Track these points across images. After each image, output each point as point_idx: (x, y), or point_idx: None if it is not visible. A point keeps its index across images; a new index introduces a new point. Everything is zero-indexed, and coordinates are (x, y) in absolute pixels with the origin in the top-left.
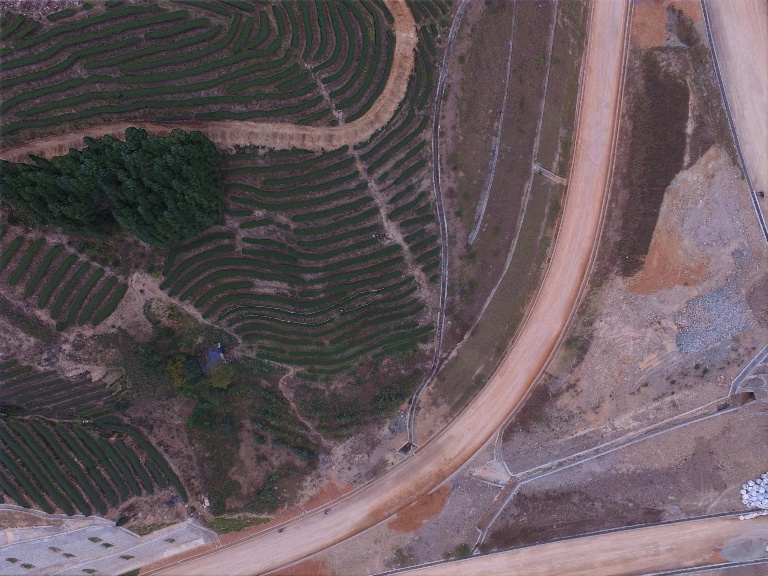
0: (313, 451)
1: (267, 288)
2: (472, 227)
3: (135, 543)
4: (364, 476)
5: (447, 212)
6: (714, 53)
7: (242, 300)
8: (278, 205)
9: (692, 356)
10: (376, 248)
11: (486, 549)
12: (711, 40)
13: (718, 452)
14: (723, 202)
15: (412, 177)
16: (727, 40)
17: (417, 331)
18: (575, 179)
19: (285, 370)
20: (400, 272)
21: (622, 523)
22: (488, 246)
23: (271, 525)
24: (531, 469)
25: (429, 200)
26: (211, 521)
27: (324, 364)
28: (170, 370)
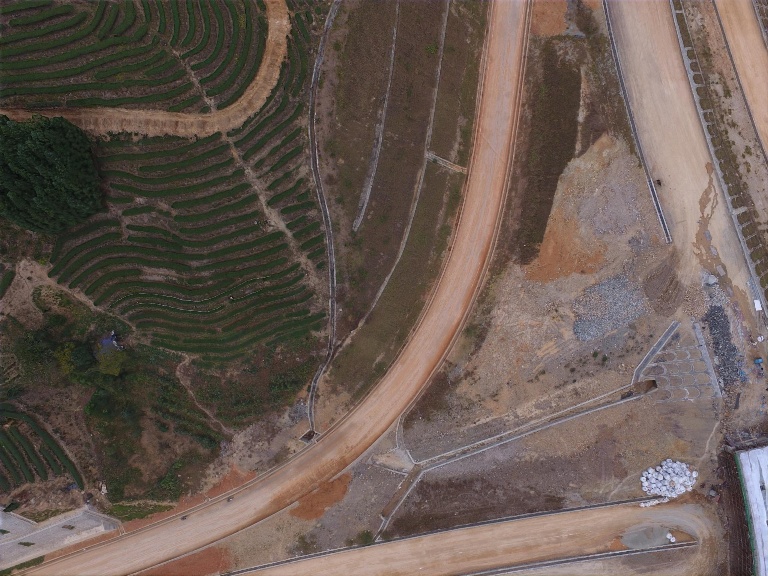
0: (214, 439)
1: (156, 275)
2: (356, 214)
3: (32, 529)
4: (266, 464)
5: (328, 199)
6: (613, 42)
7: (133, 288)
8: (156, 192)
9: (589, 344)
10: (259, 235)
11: (388, 536)
12: (610, 29)
13: (620, 440)
14: (619, 190)
15: (289, 164)
16: (626, 29)
17: (309, 318)
18: (476, 168)
19: (181, 358)
20: (285, 259)
21: (523, 510)
22: (376, 233)
23: (174, 512)
24: (434, 457)
25: (309, 187)
26: (109, 508)
27: (218, 351)
28: (57, 357)
